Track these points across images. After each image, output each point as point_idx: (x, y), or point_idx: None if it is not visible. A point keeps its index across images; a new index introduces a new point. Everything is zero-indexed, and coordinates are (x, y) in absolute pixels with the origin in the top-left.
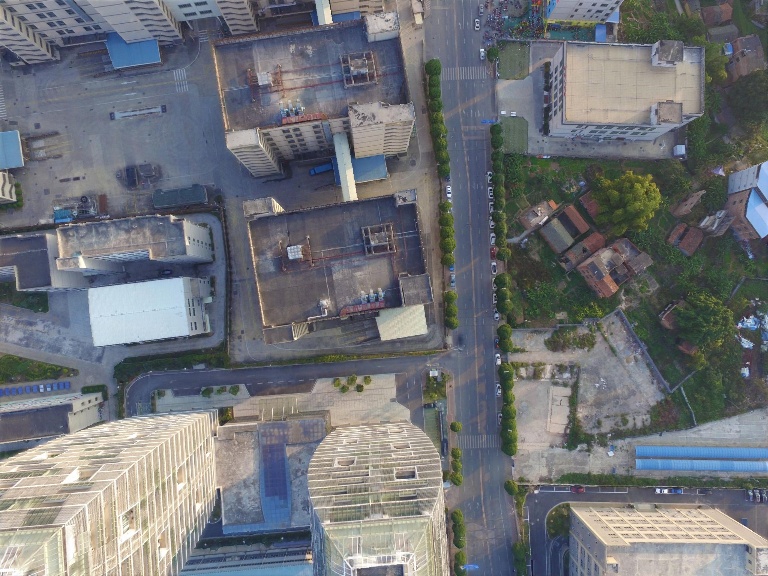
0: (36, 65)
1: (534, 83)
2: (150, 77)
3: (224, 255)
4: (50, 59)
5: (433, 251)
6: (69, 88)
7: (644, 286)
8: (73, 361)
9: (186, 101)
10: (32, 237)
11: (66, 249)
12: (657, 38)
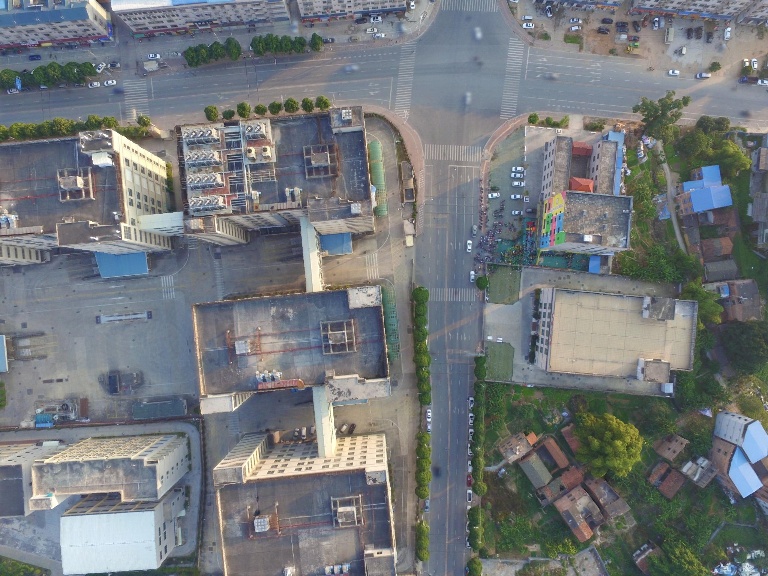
0: (26, 265)
1: (523, 309)
2: (138, 282)
3: (200, 465)
4: (40, 262)
5: (409, 473)
6: (57, 289)
7: (621, 522)
8: (46, 561)
9: (172, 308)
10: (8, 465)
11: (40, 485)
12: (652, 276)
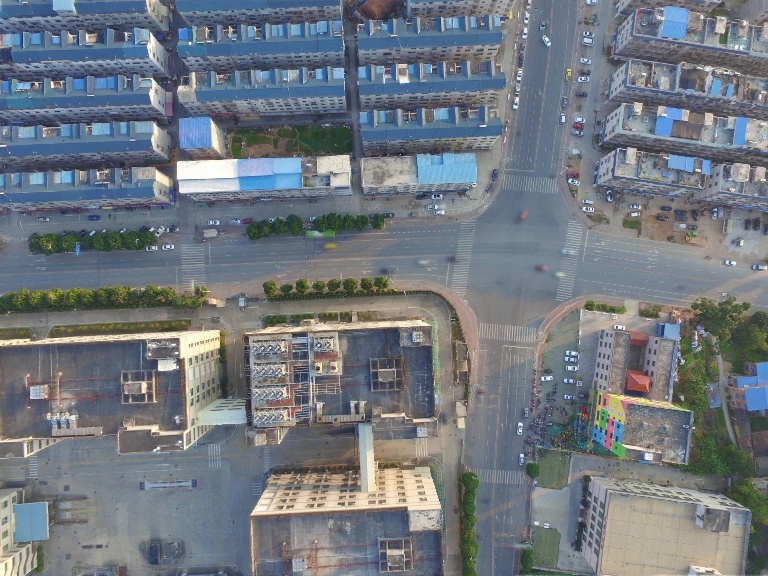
0: None
1: (571, 495)
2: None
3: None
4: None
5: None
6: (102, 453)
7: None
8: None
9: (217, 478)
10: None
11: None
12: None
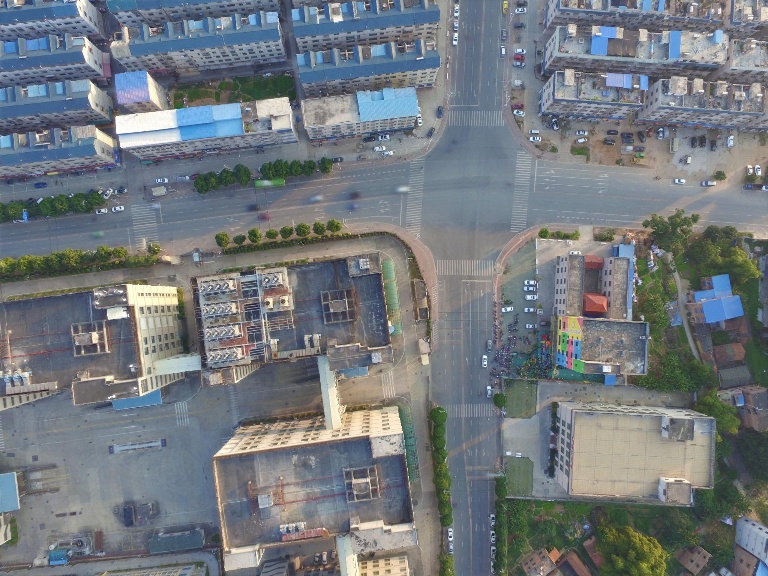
0: None
1: (541, 423)
2: (151, 410)
3: None
4: None
5: None
6: (68, 420)
7: None
8: None
9: (186, 435)
10: None
11: None
12: (667, 388)
